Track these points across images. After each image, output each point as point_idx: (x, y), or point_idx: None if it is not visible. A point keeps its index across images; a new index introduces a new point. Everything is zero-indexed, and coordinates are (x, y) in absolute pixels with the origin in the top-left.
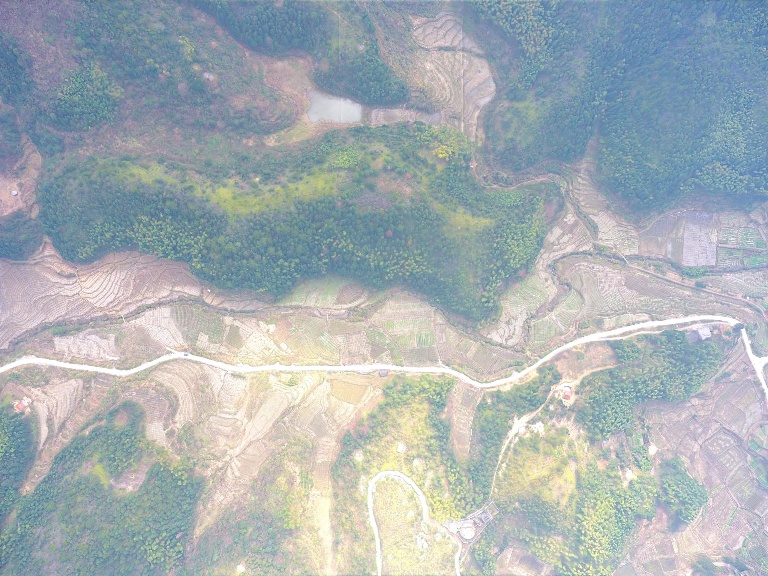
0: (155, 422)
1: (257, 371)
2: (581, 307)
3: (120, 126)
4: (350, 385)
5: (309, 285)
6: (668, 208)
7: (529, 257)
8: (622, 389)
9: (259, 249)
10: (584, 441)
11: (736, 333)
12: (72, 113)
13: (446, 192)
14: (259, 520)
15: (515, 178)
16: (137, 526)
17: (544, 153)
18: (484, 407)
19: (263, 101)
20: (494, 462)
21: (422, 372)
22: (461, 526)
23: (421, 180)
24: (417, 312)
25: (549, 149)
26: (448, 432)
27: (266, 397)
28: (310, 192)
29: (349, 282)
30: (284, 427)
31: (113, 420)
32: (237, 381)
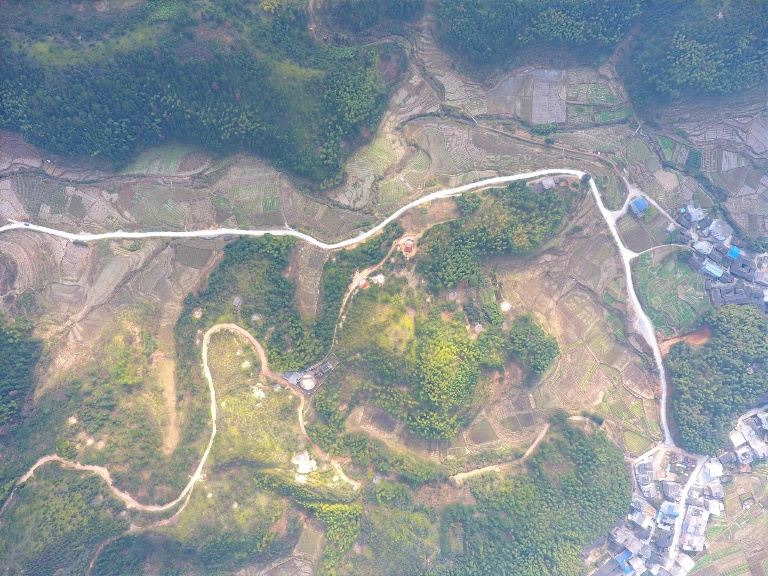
0: None
1: (99, 238)
2: (429, 167)
3: None
4: (194, 250)
5: (151, 153)
6: (514, 66)
7: (368, 113)
8: (462, 238)
9: (82, 105)
10: (426, 292)
11: (584, 185)
12: None
13: (273, 44)
14: (94, 376)
15: (357, 40)
16: None
17: (382, 11)
18: (328, 265)
19: None
20: (334, 314)
21: None
22: (301, 377)
23: (242, 29)
24: (262, 177)
25: (386, 6)
26: (291, 290)
27: (107, 262)
28: (130, 45)
29: (192, 149)
30: (127, 292)
31: None
32: (79, 249)
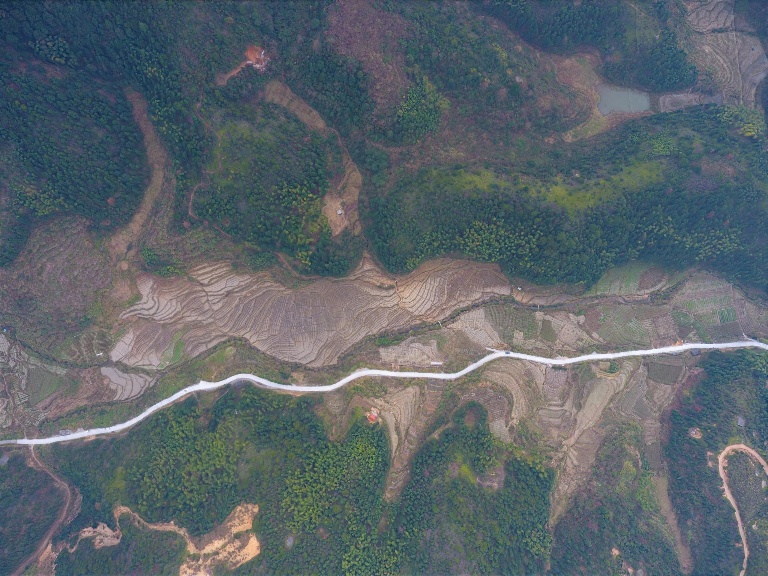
0: (497, 420)
1: (576, 362)
2: None
3: (440, 137)
4: (665, 367)
5: (612, 274)
6: None
7: None
8: None
9: (591, 242)
10: None
11: None
12: (407, 128)
13: None
14: (617, 504)
15: None
16: (519, 520)
17: None
18: None
19: (564, 99)
20: None
21: (731, 347)
22: None
23: None
24: (716, 290)
25: None
26: None
27: (593, 386)
28: (636, 182)
29: (649, 267)
30: (611, 413)
31: (464, 422)
32: (558, 373)
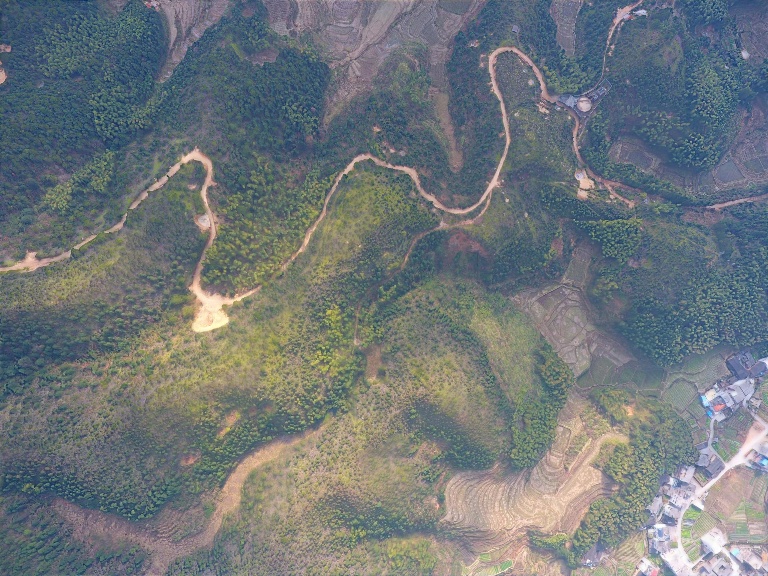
0: (278, 21)
1: None
2: None
3: None
4: None
5: None
6: None
7: None
8: None
9: None
10: None
11: None
12: None
13: None
14: None
15: None
16: (278, 84)
17: None
18: (586, 8)
19: None
20: (603, 45)
21: None
22: (578, 100)
23: None
24: None
25: None
26: (555, 28)
27: (380, 3)
28: None
29: None
30: (398, 33)
31: (240, 12)
32: None
